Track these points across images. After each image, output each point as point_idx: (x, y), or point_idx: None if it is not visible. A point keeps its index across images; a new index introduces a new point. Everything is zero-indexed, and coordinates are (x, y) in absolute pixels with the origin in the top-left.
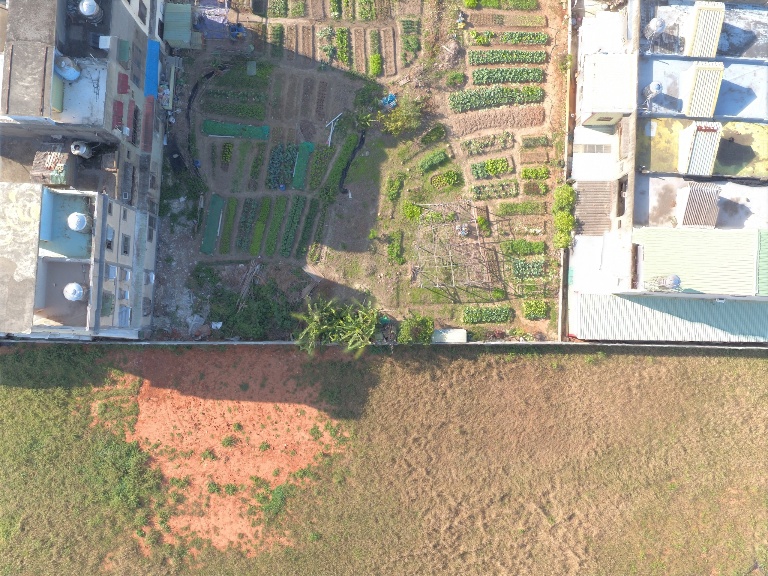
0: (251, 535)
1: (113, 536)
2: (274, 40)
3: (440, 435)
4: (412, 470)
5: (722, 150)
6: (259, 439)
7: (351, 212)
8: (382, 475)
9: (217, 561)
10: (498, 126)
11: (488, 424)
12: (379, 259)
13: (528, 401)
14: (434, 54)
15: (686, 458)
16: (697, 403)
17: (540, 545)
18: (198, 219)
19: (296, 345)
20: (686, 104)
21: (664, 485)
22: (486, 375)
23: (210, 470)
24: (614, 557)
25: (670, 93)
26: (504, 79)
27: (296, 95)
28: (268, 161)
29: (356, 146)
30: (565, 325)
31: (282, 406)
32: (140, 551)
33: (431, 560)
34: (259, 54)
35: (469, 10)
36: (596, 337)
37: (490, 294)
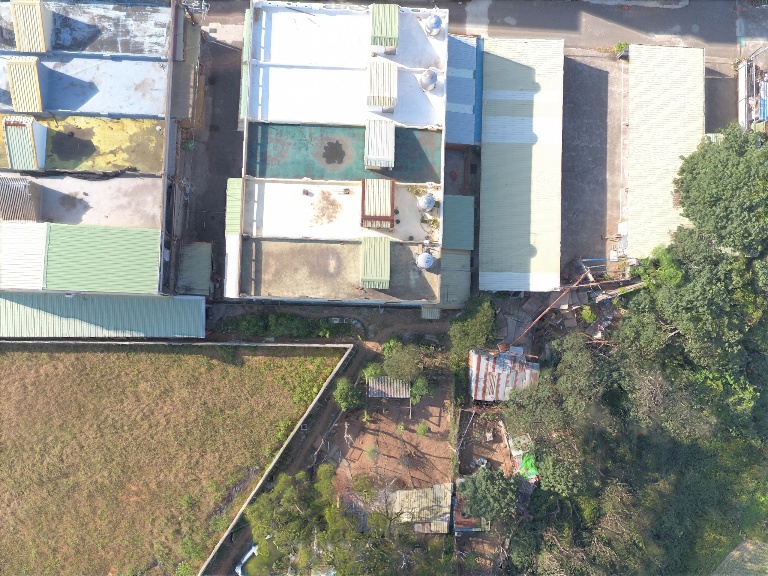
0: None
1: None
2: None
3: None
4: None
5: (61, 145)
6: None
7: None
8: None
9: None
10: None
11: None
12: None
13: None
14: None
15: (81, 455)
16: (95, 399)
17: None
18: None
19: None
20: None
21: (60, 482)
22: None
23: None
24: (5, 556)
25: (9, 89)
26: None
27: None
28: None
29: None
30: None
31: None
32: None
33: None
34: None
35: None
36: None
37: None
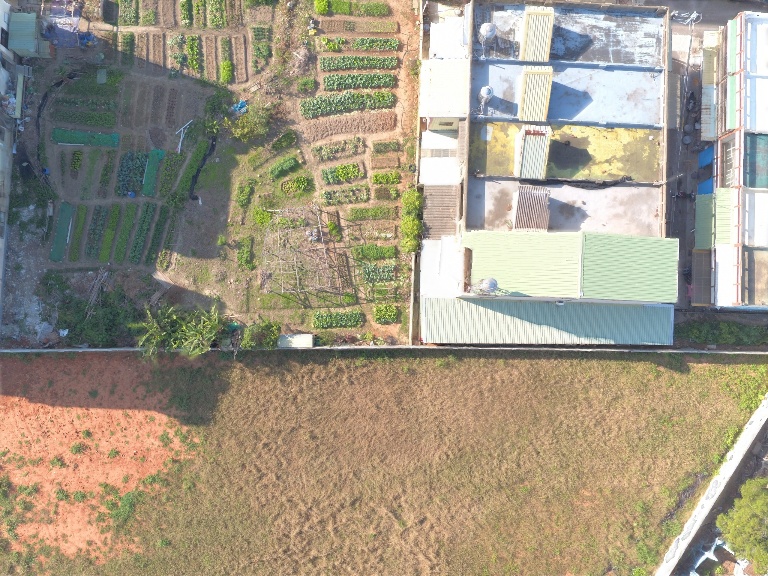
0: (100, 542)
1: None
2: (124, 48)
3: (290, 440)
4: (262, 475)
5: (558, 153)
6: (108, 446)
7: (201, 218)
8: (232, 481)
9: (65, 568)
10: (349, 131)
11: (339, 429)
12: (229, 265)
13: (379, 405)
14: (285, 61)
15: (538, 461)
16: (549, 406)
17: (391, 549)
18: (46, 227)
19: None
20: (519, 108)
21: (517, 488)
22: (337, 380)
23: (59, 477)
24: (466, 560)
25: (506, 97)
26: (355, 85)
27: (146, 103)
28: (118, 168)
29: (206, 153)
30: (418, 329)
31: (131, 413)
32: None
33: (281, 565)
34: (110, 62)
35: (321, 17)
36: (442, 341)
37: (341, 299)
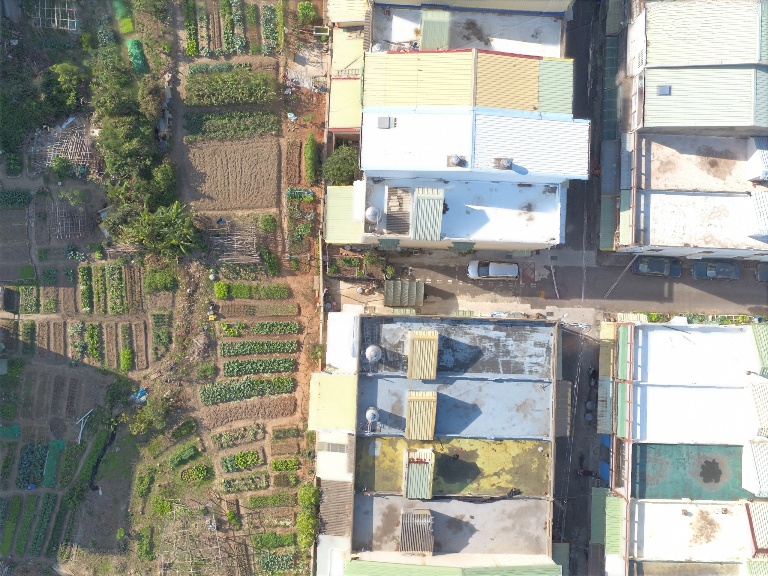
0: None
1: None
2: (25, 338)
3: None
4: None
5: (447, 467)
6: None
7: (102, 508)
8: None
9: None
10: (249, 417)
11: None
12: (129, 555)
13: None
14: (185, 347)
15: None
16: None
17: None
18: None
19: None
20: (405, 428)
21: None
22: None
23: None
24: None
25: (394, 411)
26: (255, 371)
27: (46, 393)
28: (18, 460)
29: (107, 442)
30: None
31: None
32: None
33: None
34: (11, 352)
35: (221, 301)
36: None
37: None
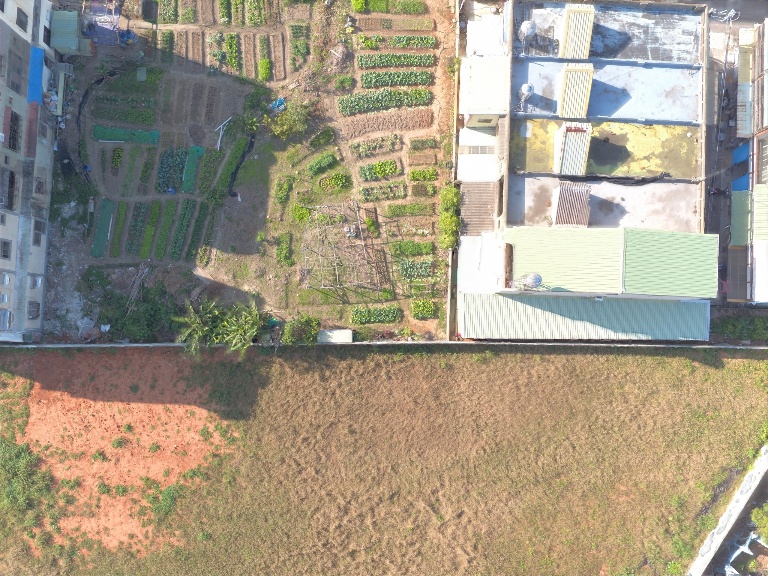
0: (141, 535)
1: (3, 537)
2: (164, 46)
3: (329, 434)
4: (301, 469)
5: (597, 150)
6: (149, 440)
7: (240, 215)
8: (271, 475)
9: (107, 561)
10: (387, 129)
11: (377, 423)
12: (268, 261)
13: (417, 400)
14: (323, 58)
15: (575, 455)
16: (585, 401)
17: (429, 543)
18: (87, 223)
19: None
20: (559, 105)
21: (553, 482)
22: (375, 375)
23: (100, 471)
24: (503, 554)
25: (545, 94)
26: (392, 82)
27: (185, 100)
28: (158, 165)
29: (245, 150)
30: (454, 325)
31: (172, 407)
32: (30, 552)
33: (320, 559)
34: (149, 60)
35: (358, 15)
36: (480, 336)
37: (378, 295)
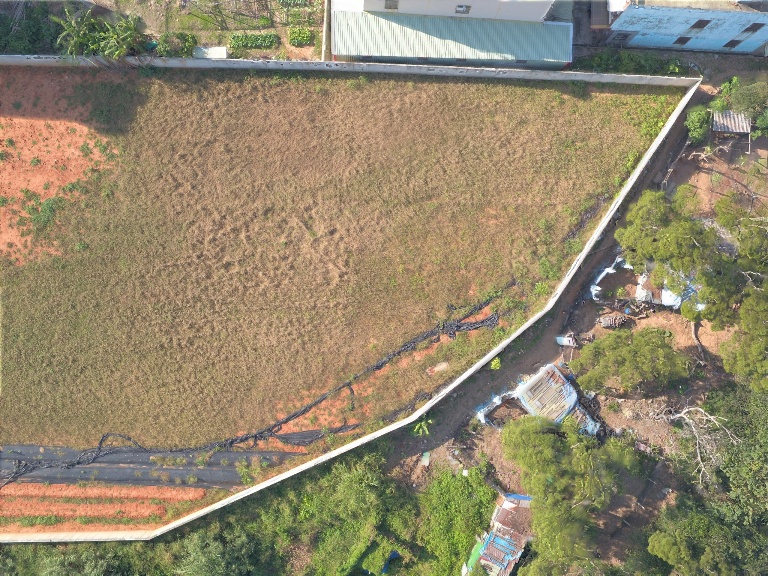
0: (20, 244)
1: None
2: None
3: (206, 153)
4: (178, 185)
5: None
6: (30, 154)
7: None
8: (149, 189)
9: None
10: None
11: (253, 143)
12: None
13: (292, 123)
14: None
15: (445, 178)
16: (456, 127)
17: (302, 257)
18: None
19: (68, 68)
20: None
21: (424, 204)
22: (251, 97)
23: None
24: (374, 270)
25: None
26: None
27: None
28: None
29: None
30: (331, 54)
31: (53, 124)
32: None
33: (195, 270)
34: None
35: None
36: (350, 53)
37: (256, 22)
